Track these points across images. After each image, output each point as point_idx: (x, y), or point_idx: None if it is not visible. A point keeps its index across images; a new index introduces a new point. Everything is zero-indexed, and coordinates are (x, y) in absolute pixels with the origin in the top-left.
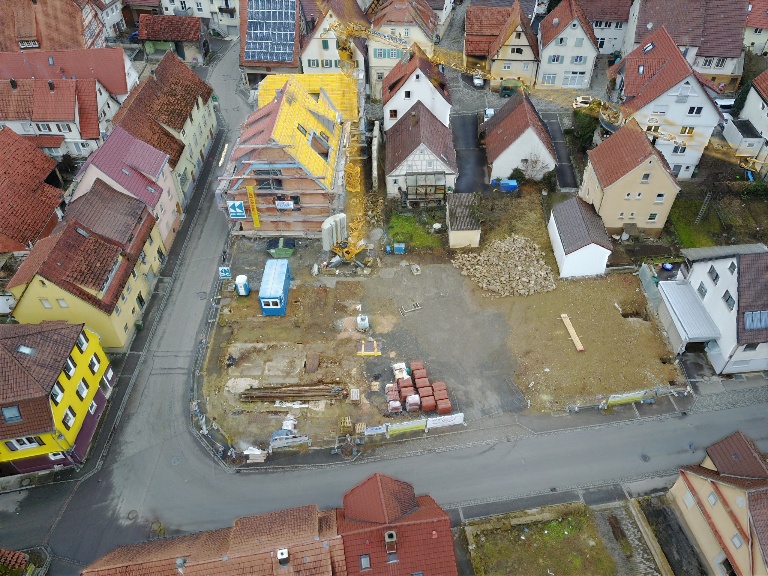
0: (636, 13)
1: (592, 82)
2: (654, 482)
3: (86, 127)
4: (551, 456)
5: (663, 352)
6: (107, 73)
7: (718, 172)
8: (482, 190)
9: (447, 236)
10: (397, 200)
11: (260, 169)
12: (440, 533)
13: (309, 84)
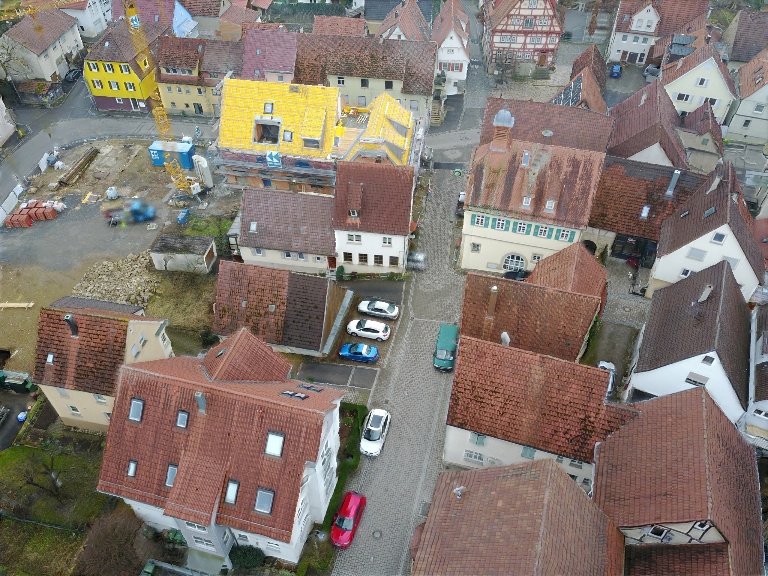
0: None
1: None
2: None
3: None
4: None
5: None
6: None
7: None
8: None
9: None
10: None
11: None
12: None
13: None
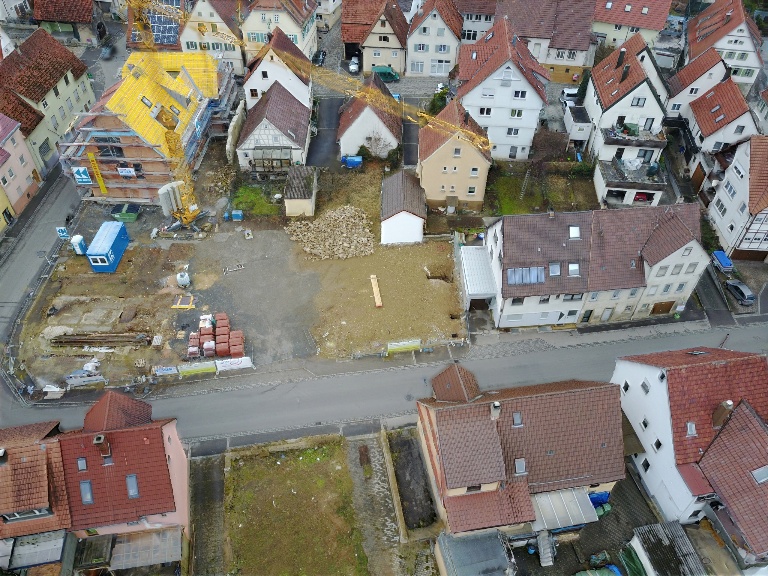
0: None
1: None
2: (410, 418)
3: None
4: (325, 395)
5: (455, 309)
6: None
7: None
8: (332, 166)
9: None
10: (250, 173)
11: (100, 137)
12: (152, 440)
13: (171, 62)
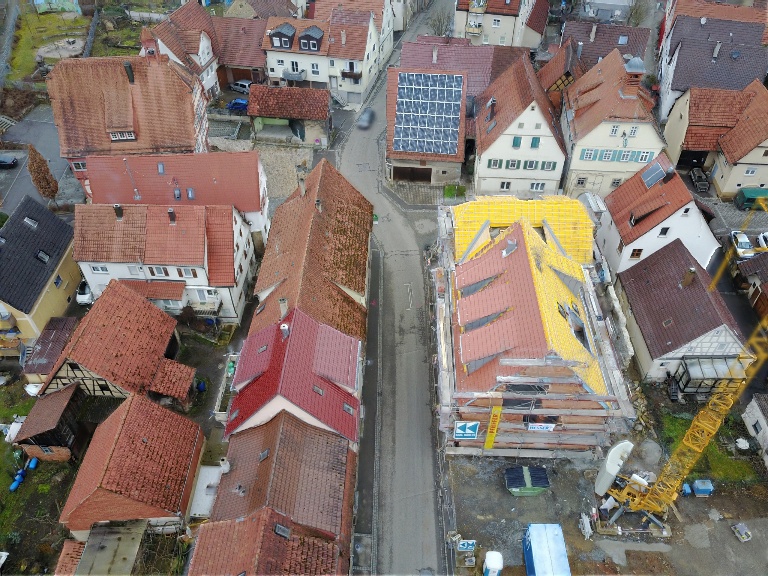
0: None
1: None
2: None
3: (216, 270)
4: None
5: None
6: (235, 184)
7: None
8: None
9: (762, 462)
10: (659, 386)
11: (516, 383)
12: None
13: (527, 215)
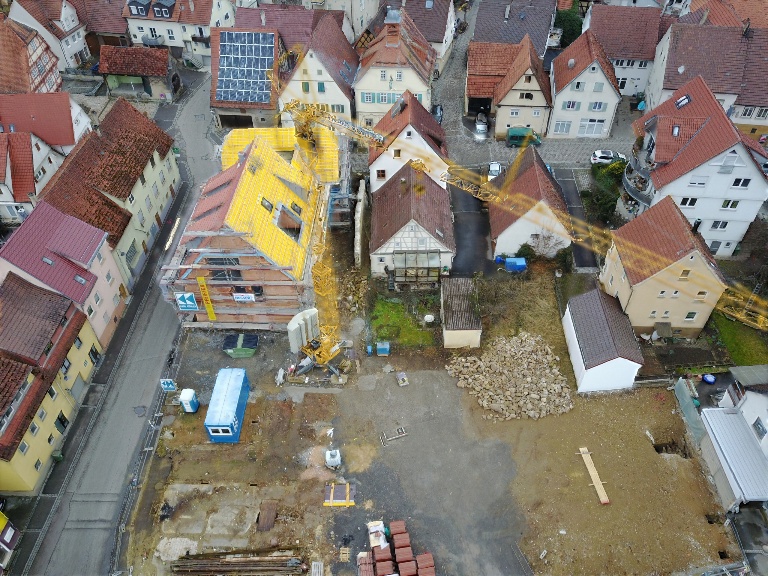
0: (665, 53)
1: (612, 130)
2: None
3: (20, 188)
4: None
5: (709, 506)
6: (51, 121)
7: (763, 248)
8: (484, 268)
9: (441, 332)
10: (383, 280)
11: (213, 257)
12: None
13: (282, 140)
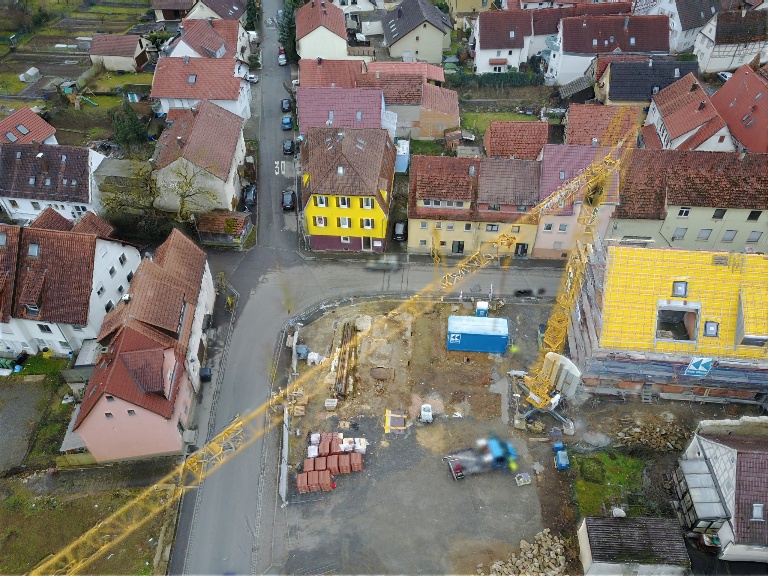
0: None
1: None
2: None
3: None
4: None
5: None
6: None
7: None
8: None
9: None
10: None
11: None
12: None
13: None
